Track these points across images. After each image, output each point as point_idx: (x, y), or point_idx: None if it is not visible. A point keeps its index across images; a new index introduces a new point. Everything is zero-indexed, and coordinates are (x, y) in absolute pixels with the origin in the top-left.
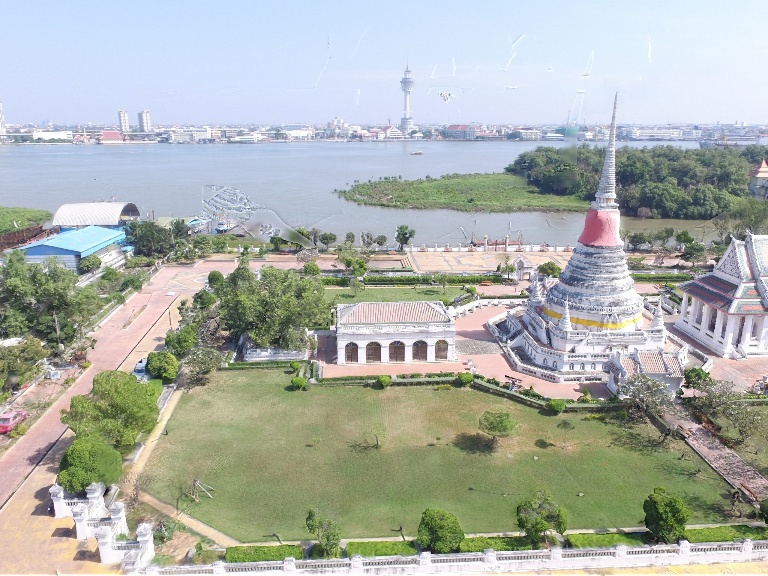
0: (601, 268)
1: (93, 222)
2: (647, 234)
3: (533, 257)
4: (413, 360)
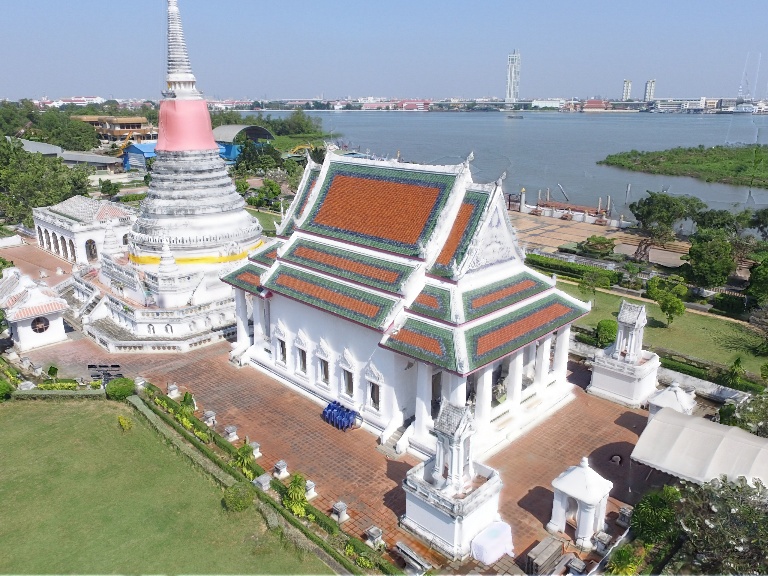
0: (152, 180)
1: (223, 139)
2: (735, 214)
3: (521, 221)
4: (64, 256)
